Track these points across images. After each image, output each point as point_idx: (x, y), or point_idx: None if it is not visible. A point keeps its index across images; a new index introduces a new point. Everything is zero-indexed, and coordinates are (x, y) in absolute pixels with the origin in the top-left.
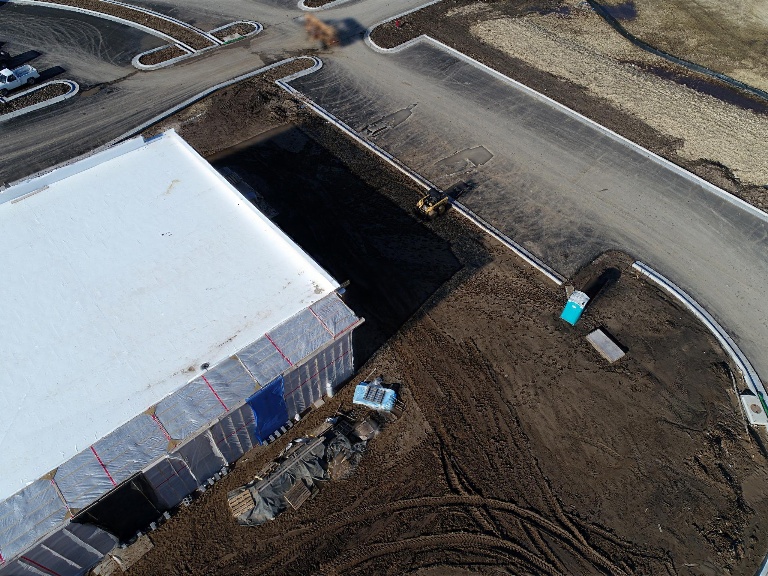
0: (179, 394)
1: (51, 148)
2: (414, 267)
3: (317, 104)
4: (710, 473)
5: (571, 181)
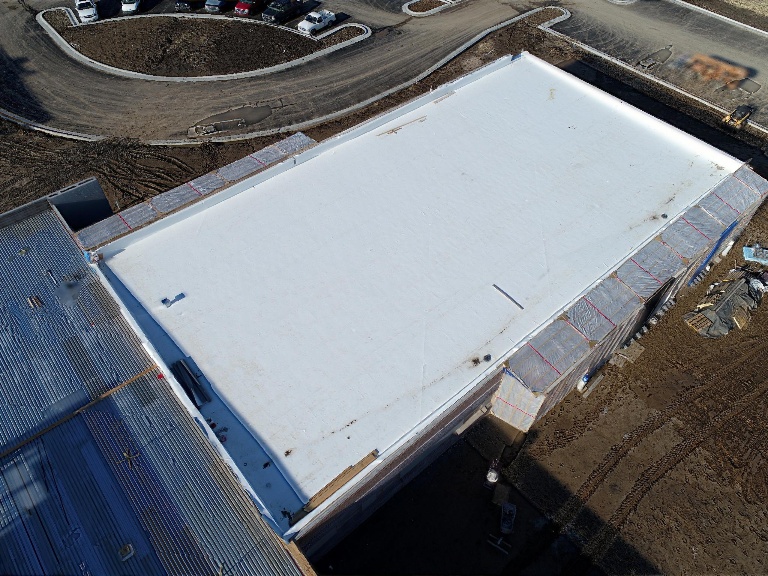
0: (672, 229)
1: (379, 76)
2: None
3: (586, 44)
4: None
5: None
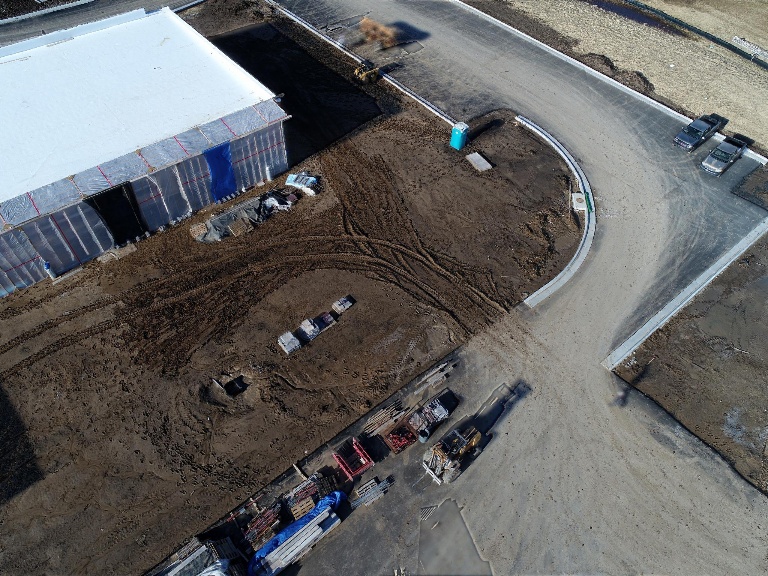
0: (157, 145)
1: None
2: (345, 112)
3: (289, 10)
4: (534, 232)
5: (482, 65)
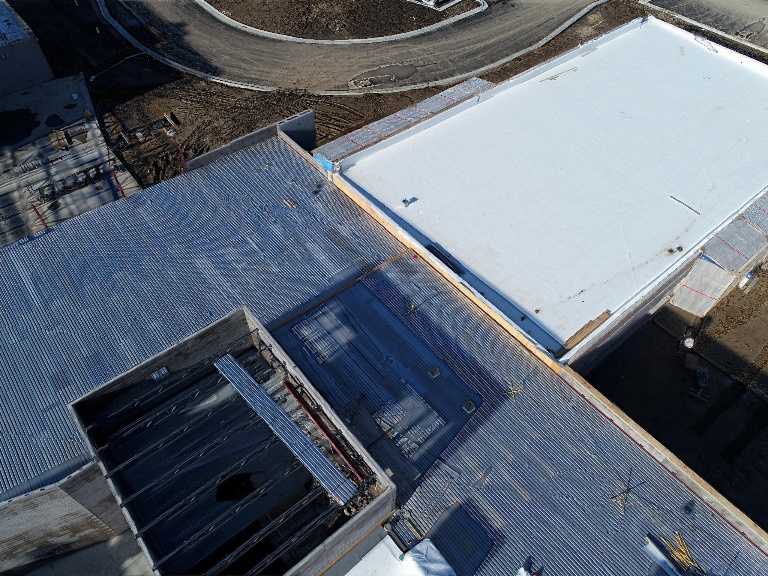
0: None
1: (504, 41)
2: None
3: (686, 17)
4: None
5: None
